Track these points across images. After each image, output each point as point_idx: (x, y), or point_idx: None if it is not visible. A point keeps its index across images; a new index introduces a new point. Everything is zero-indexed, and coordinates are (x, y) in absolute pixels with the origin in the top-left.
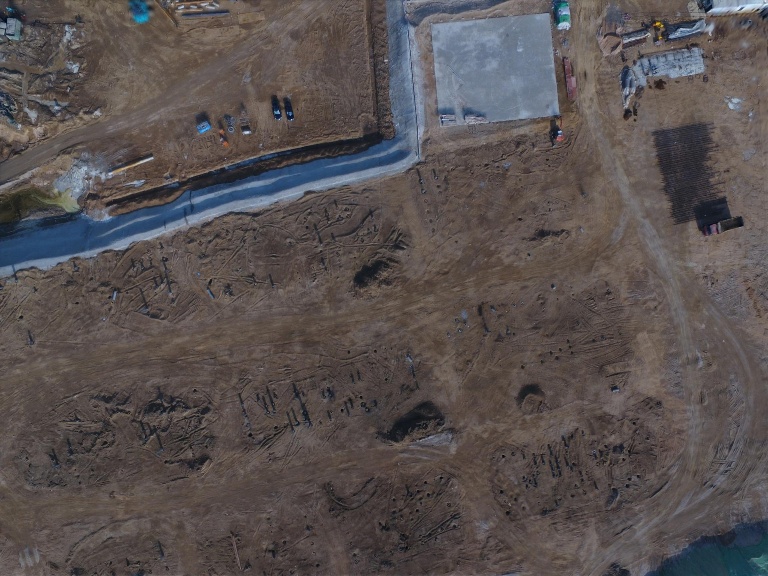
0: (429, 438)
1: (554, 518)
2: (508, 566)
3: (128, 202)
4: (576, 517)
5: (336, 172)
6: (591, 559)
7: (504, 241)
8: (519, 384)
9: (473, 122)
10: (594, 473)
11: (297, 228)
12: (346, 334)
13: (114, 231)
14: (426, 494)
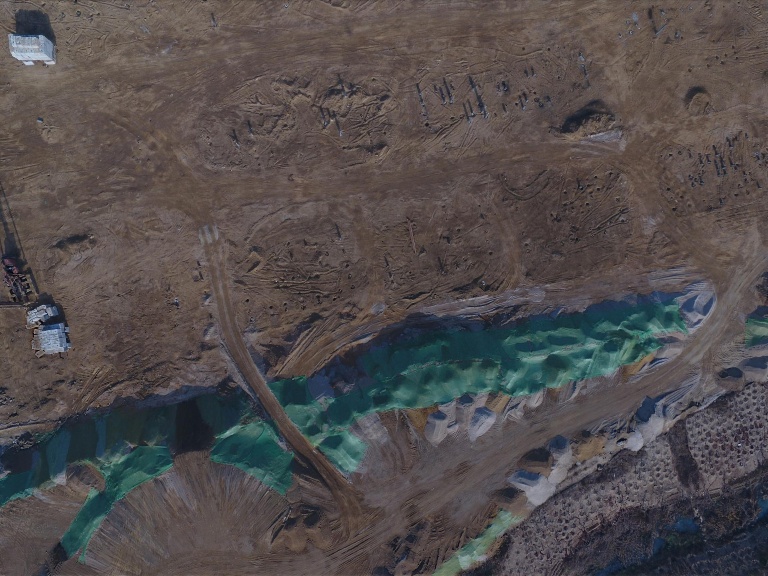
0: (600, 135)
1: (718, 215)
2: (674, 261)
3: None
4: (739, 215)
5: None
6: (753, 256)
7: None
8: (686, 86)
9: None
10: (757, 174)
11: None
12: (521, 31)
13: None
14: (596, 188)
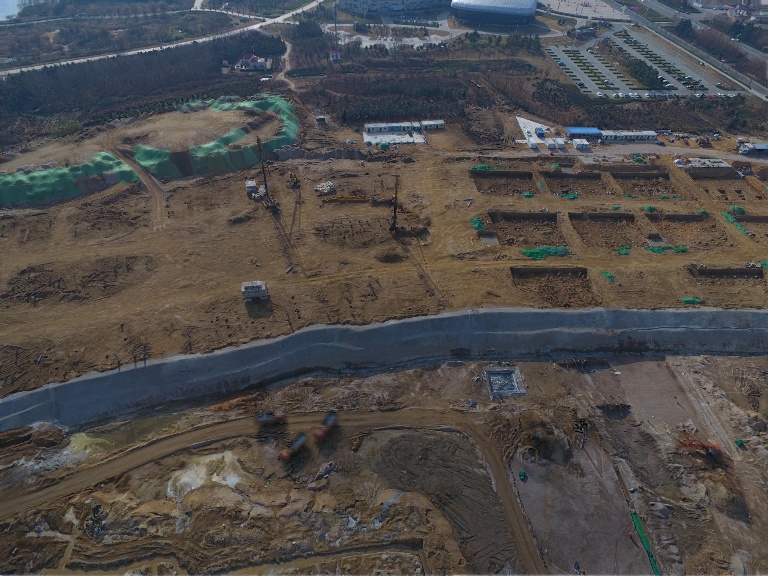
0: None
1: None
2: None
3: (6, 439)
4: None
5: None
6: None
7: None
8: None
9: None
10: None
11: None
12: None
13: (25, 410)
14: None
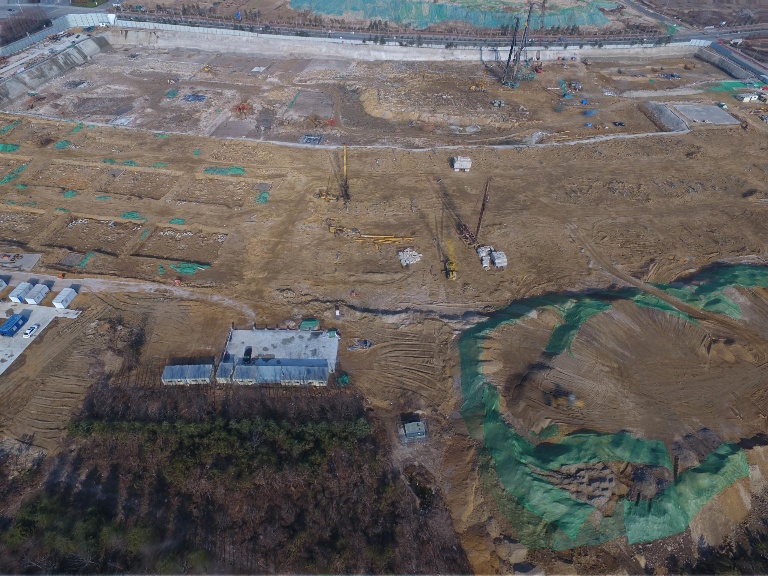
0: (765, 199)
1: None
2: None
3: None
4: None
5: None
6: None
7: (748, 150)
8: None
9: (708, 122)
10: None
11: None
12: None
13: None
14: None
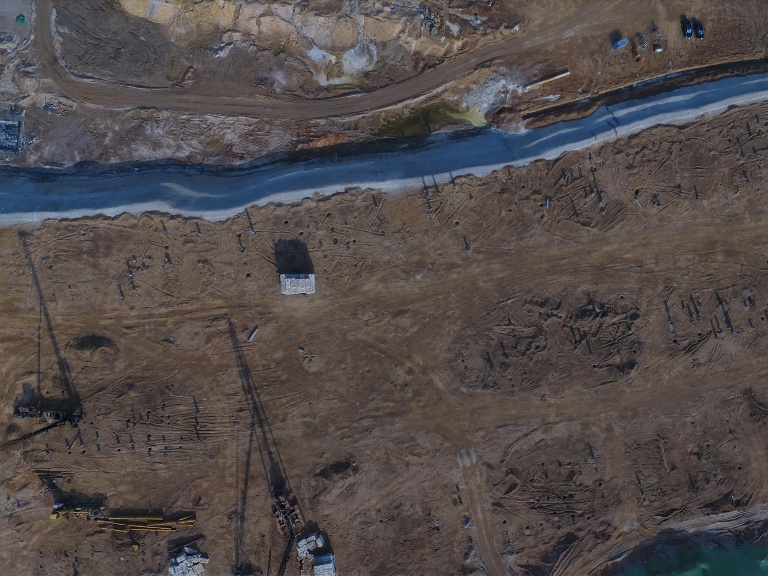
0: None
1: None
2: None
3: (545, 115)
4: None
5: (755, 88)
6: None
7: None
8: None
9: None
10: None
11: (720, 141)
12: (766, 245)
13: (538, 142)
14: None
